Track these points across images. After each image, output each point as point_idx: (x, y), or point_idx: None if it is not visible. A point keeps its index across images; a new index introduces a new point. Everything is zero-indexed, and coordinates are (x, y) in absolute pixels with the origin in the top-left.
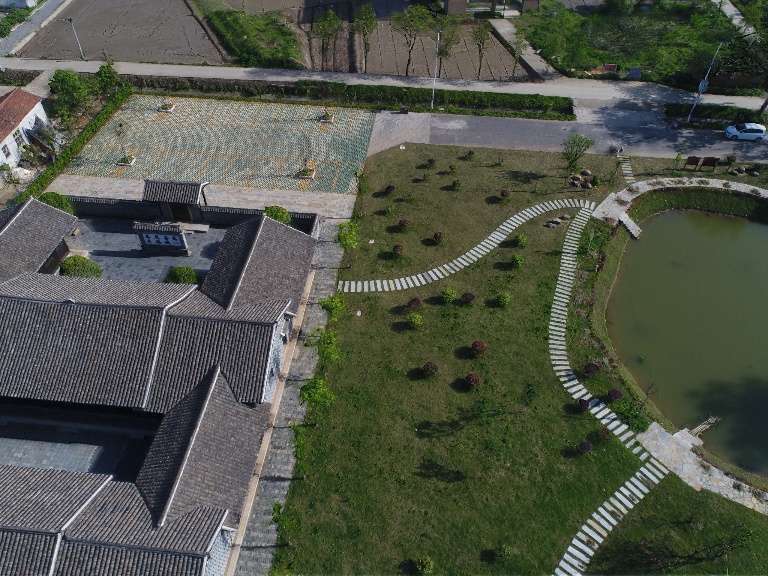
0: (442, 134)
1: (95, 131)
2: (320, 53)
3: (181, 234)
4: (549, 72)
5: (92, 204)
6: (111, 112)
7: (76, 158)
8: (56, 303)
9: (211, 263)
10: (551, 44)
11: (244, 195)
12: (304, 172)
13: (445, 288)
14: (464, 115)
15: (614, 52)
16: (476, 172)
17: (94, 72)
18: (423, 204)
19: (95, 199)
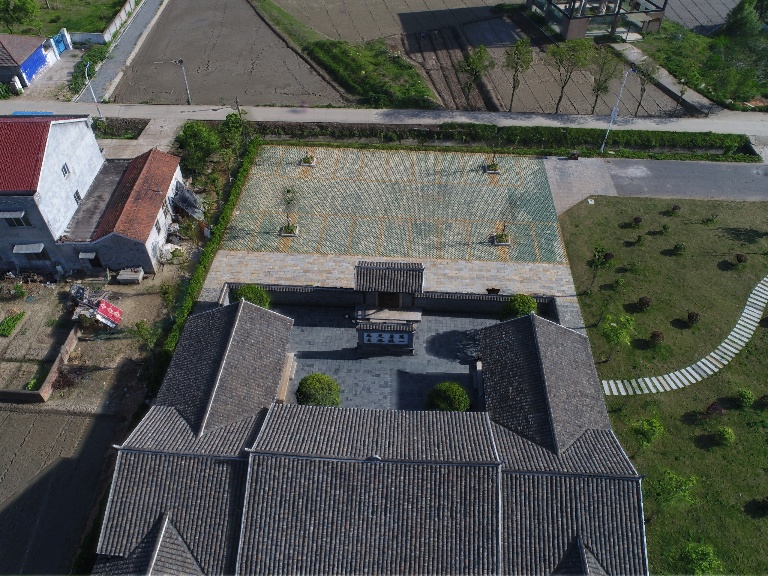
0: (627, 184)
1: (238, 193)
2: (446, 88)
3: (413, 333)
4: (707, 104)
5: (281, 292)
6: (247, 168)
7: (229, 228)
8: (356, 461)
9: (443, 363)
10: (722, 76)
11: (442, 270)
12: (500, 238)
13: (730, 385)
14: (640, 159)
15: (760, 78)
16: (691, 231)
17: (209, 119)
18: (651, 274)
19: (287, 287)
